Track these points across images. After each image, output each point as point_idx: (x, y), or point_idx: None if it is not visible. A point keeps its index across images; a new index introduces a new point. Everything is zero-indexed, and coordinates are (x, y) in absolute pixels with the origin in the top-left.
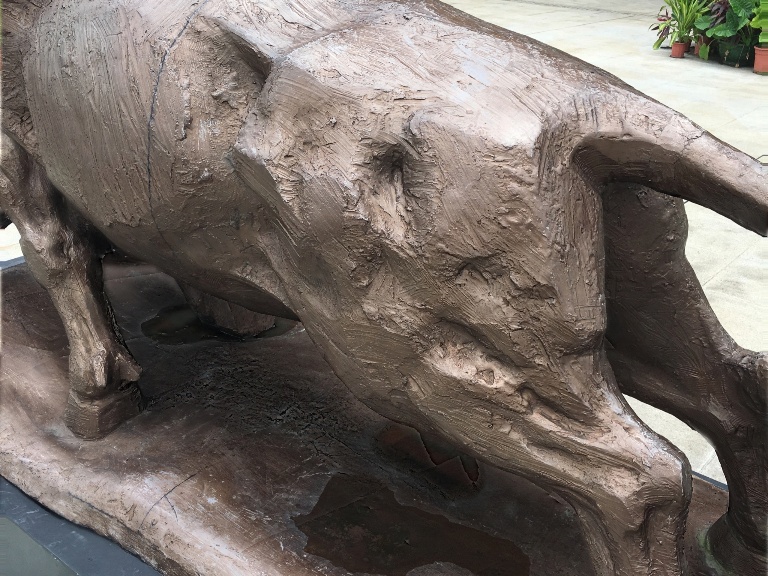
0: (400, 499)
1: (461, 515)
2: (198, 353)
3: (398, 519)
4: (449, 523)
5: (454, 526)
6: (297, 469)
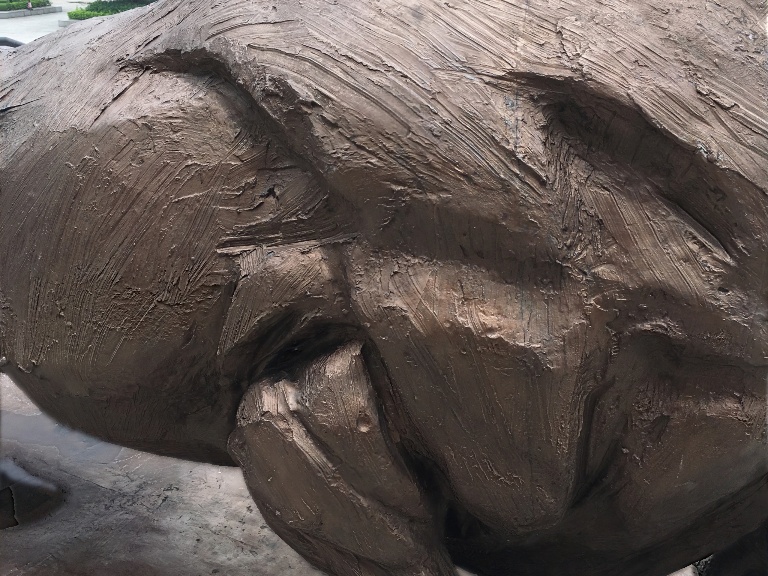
0: (55, 450)
1: (5, 445)
2: None
3: (60, 437)
4: (18, 439)
5: (14, 438)
6: (146, 458)
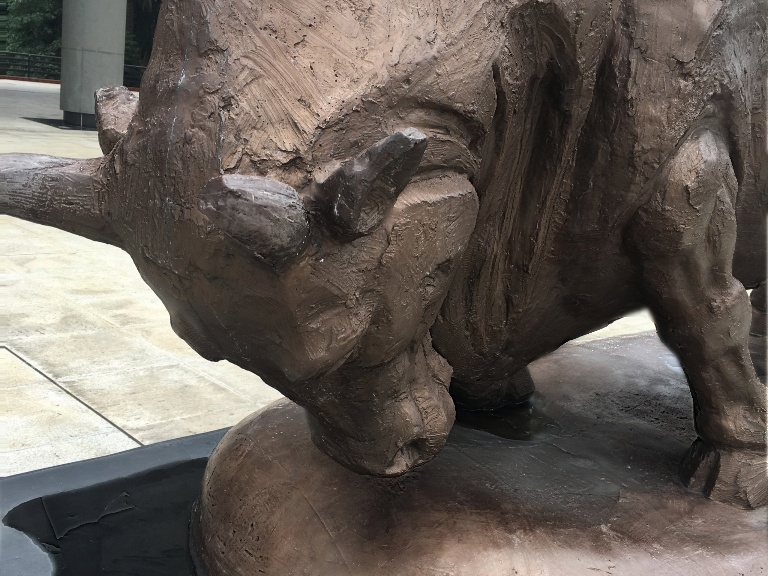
0: None
1: None
2: (583, 416)
3: None
4: None
5: None
6: None
